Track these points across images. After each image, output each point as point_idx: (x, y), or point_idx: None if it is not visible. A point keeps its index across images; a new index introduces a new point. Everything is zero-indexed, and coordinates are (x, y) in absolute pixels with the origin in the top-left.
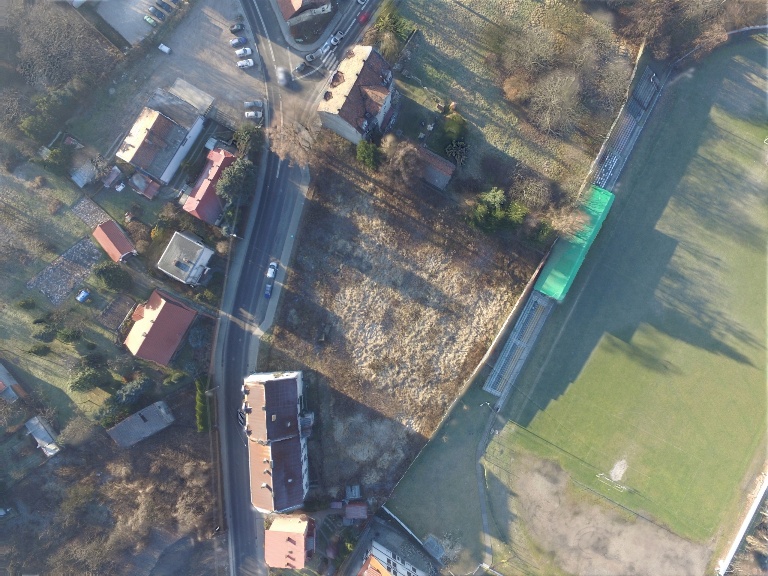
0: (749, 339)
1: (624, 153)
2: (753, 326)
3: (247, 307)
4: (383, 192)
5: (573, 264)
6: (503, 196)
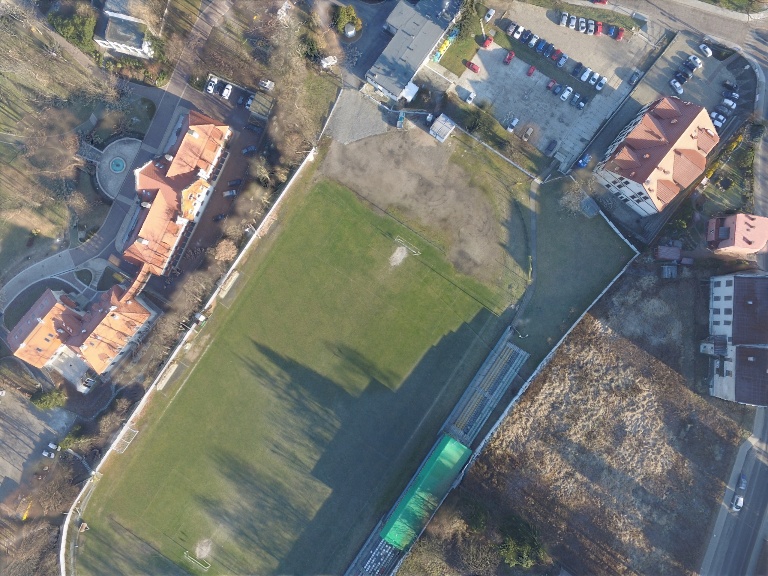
0: (254, 368)
1: (355, 572)
2: (248, 381)
3: (763, 467)
4: (617, 570)
5: (432, 472)
6: (513, 562)
